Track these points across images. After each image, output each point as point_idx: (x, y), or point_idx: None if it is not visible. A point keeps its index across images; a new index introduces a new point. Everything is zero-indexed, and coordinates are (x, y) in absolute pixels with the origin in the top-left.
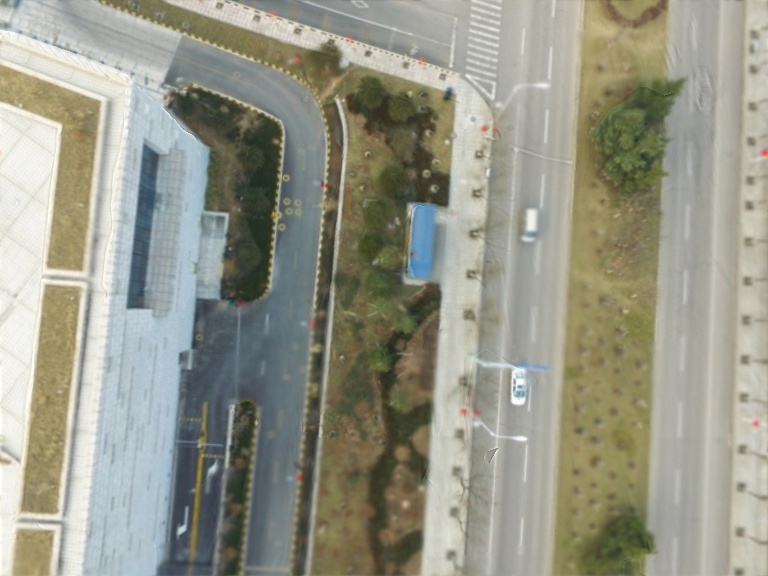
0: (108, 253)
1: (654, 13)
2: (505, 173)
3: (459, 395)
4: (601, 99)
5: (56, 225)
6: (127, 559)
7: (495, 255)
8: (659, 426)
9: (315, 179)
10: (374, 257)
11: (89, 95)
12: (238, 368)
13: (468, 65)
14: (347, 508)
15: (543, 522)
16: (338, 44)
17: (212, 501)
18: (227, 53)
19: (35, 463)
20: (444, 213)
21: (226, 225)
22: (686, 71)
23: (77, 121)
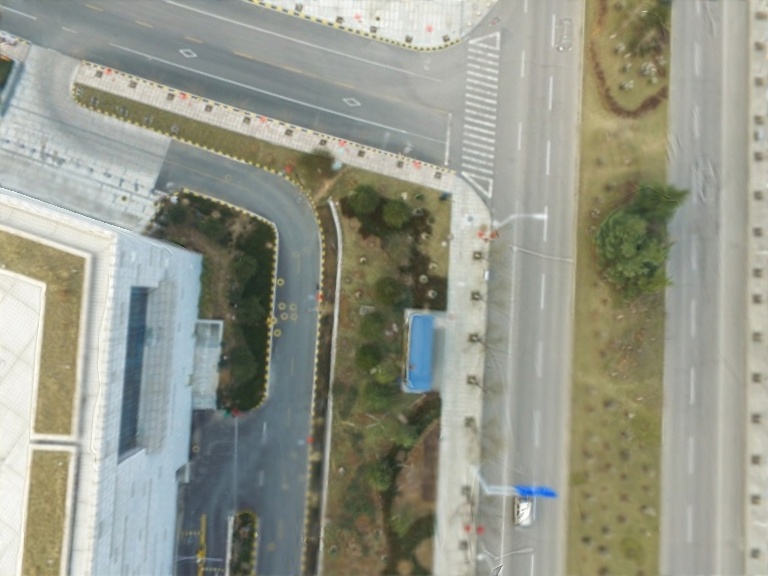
0: (96, 417)
1: (654, 103)
2: (504, 274)
3: (462, 507)
4: (601, 195)
5: (42, 388)
6: None
7: (496, 359)
8: (668, 532)
9: (310, 282)
10: (372, 367)
11: (73, 252)
12: (236, 479)
13: (464, 162)
14: None
15: None
16: (330, 145)
17: None
18: (218, 156)
19: None
20: (442, 318)
21: (221, 333)
22: (688, 161)
23: (61, 281)
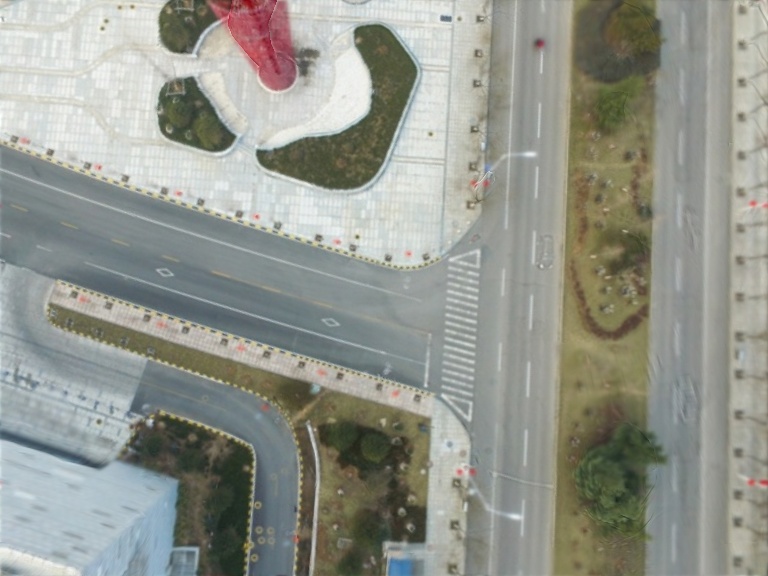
0: None
1: (635, 322)
2: (484, 503)
3: None
4: (581, 422)
5: None
6: None
7: None
8: None
9: (288, 504)
10: None
11: None
12: None
13: (443, 384)
14: None
15: None
16: (309, 368)
17: None
18: (194, 376)
19: None
20: (421, 551)
21: (196, 560)
22: (669, 381)
23: None
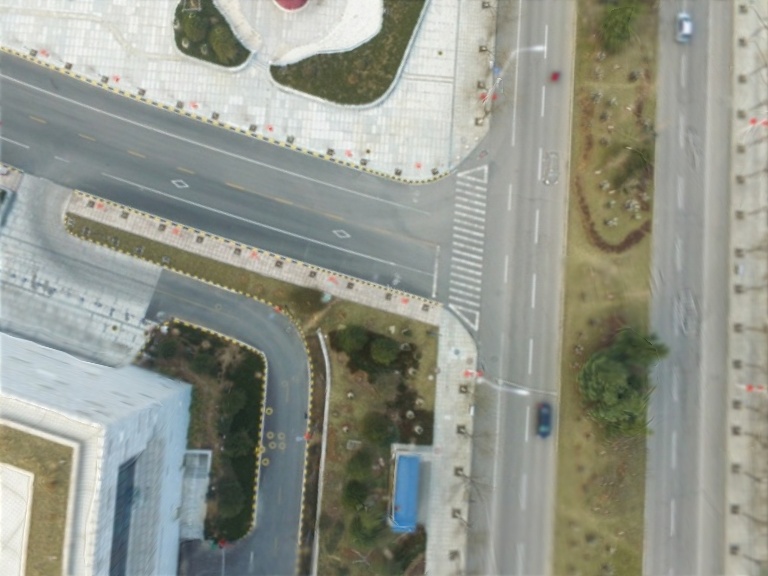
0: None
1: (637, 237)
2: (489, 409)
3: None
4: (585, 331)
5: None
6: None
7: (480, 493)
8: None
9: (298, 411)
10: (358, 503)
11: (61, 442)
12: None
13: (451, 294)
14: None
15: None
16: (320, 277)
17: None
18: (208, 285)
19: None
20: (428, 453)
21: (209, 463)
22: (670, 294)
23: (49, 472)
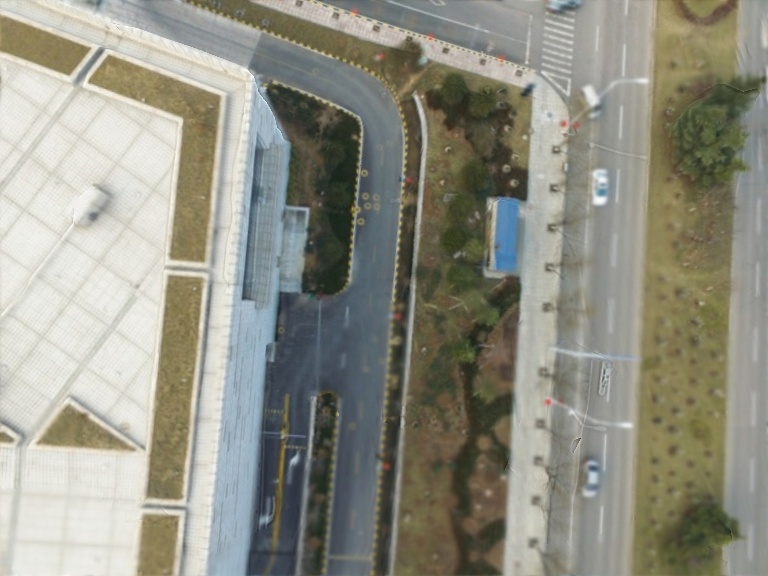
0: (230, 244)
1: (725, 11)
2: (582, 168)
3: (540, 386)
4: (675, 95)
5: (178, 217)
6: (233, 546)
7: (573, 249)
8: (734, 416)
9: (393, 174)
10: (456, 250)
11: (209, 90)
12: (319, 360)
13: (543, 62)
14: (431, 497)
15: (623, 510)
16: (416, 41)
17: (296, 491)
18: (306, 50)
19: (160, 450)
20: (523, 207)
21: (307, 219)
22: (756, 68)
23: (199, 115)
